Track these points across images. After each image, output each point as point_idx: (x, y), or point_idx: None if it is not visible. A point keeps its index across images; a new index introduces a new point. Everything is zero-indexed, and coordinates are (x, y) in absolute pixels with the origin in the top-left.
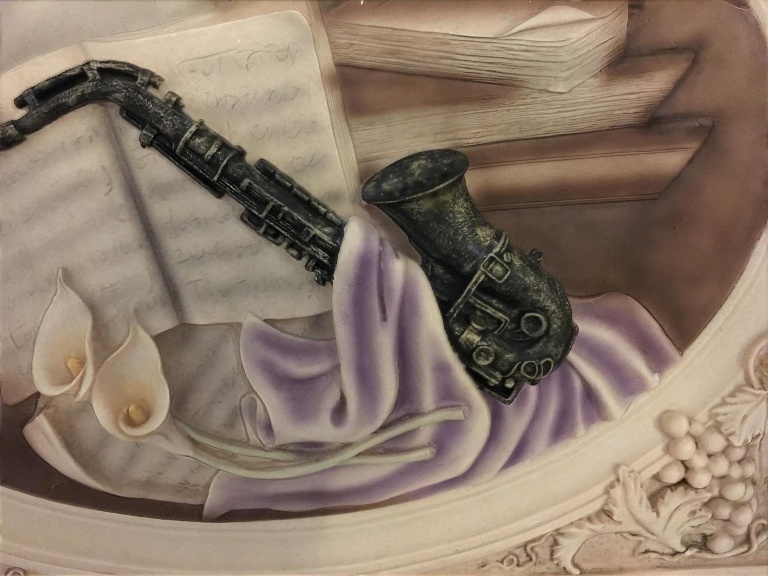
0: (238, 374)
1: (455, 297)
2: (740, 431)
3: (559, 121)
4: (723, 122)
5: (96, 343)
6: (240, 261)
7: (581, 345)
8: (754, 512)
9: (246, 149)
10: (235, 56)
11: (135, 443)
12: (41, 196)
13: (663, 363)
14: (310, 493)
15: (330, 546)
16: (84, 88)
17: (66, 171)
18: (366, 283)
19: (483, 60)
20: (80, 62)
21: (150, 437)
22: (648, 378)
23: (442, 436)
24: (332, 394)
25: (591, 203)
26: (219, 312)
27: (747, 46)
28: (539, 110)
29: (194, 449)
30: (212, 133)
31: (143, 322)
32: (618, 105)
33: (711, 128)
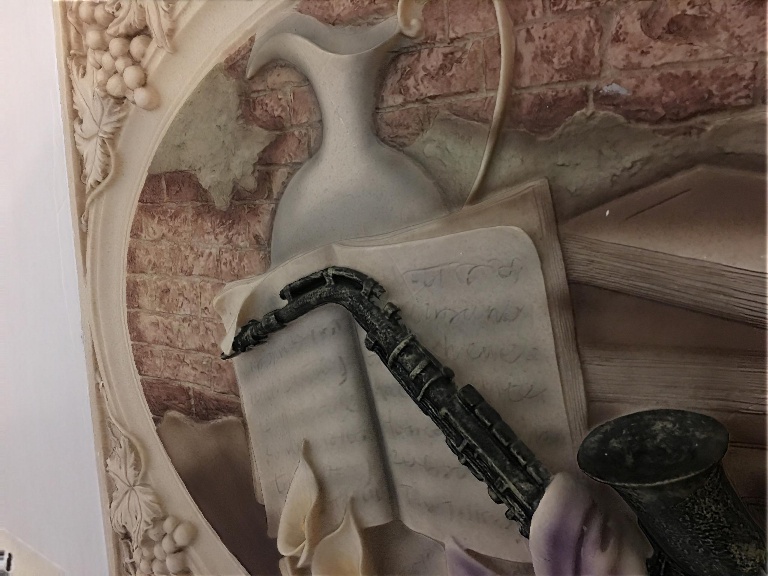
0: None
1: None
2: None
3: None
4: None
5: (317, 520)
6: (447, 481)
7: None
8: None
9: (461, 366)
10: (456, 269)
11: None
12: (296, 374)
13: None
14: None
15: None
16: (321, 292)
17: (313, 357)
18: (561, 566)
19: None
20: (332, 260)
21: None
22: None
23: None
24: None
25: None
26: (425, 525)
27: None
28: None
29: None
30: (421, 351)
31: (357, 512)
32: None
33: None
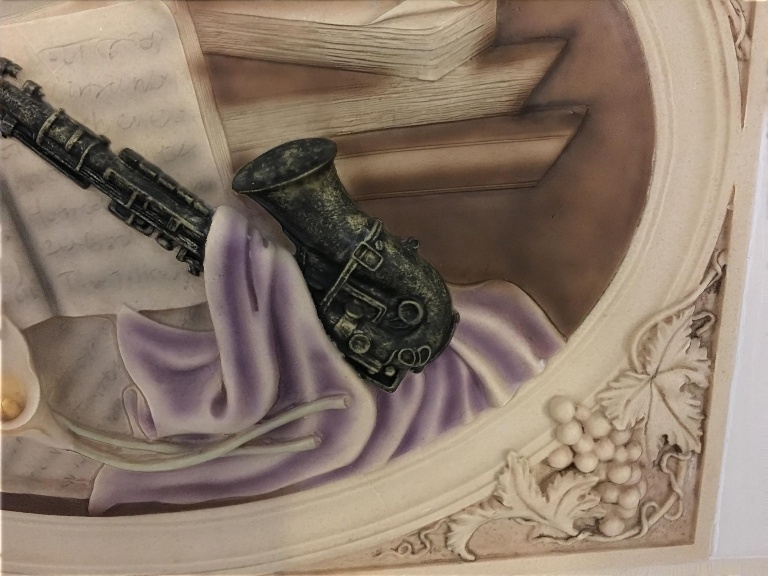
0: (119, 366)
1: (329, 286)
2: (623, 415)
3: (432, 109)
4: (597, 110)
5: None
6: (111, 252)
7: (466, 333)
8: (642, 495)
9: (113, 139)
10: (97, 44)
11: (16, 438)
12: None
13: (548, 349)
14: (199, 485)
15: (223, 538)
16: None
17: None
18: (235, 272)
19: (352, 48)
20: None
21: (24, 431)
22: (533, 364)
23: (329, 425)
24: (213, 385)
25: (469, 191)
26: (92, 304)
27: (618, 34)
28: (411, 98)
29: (75, 443)
30: (73, 122)
31: (12, 315)
32: (490, 93)
33: (585, 116)
